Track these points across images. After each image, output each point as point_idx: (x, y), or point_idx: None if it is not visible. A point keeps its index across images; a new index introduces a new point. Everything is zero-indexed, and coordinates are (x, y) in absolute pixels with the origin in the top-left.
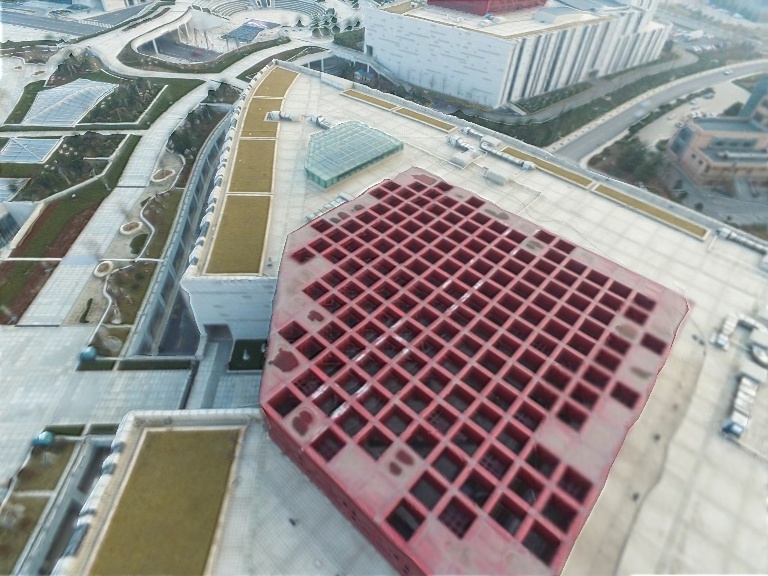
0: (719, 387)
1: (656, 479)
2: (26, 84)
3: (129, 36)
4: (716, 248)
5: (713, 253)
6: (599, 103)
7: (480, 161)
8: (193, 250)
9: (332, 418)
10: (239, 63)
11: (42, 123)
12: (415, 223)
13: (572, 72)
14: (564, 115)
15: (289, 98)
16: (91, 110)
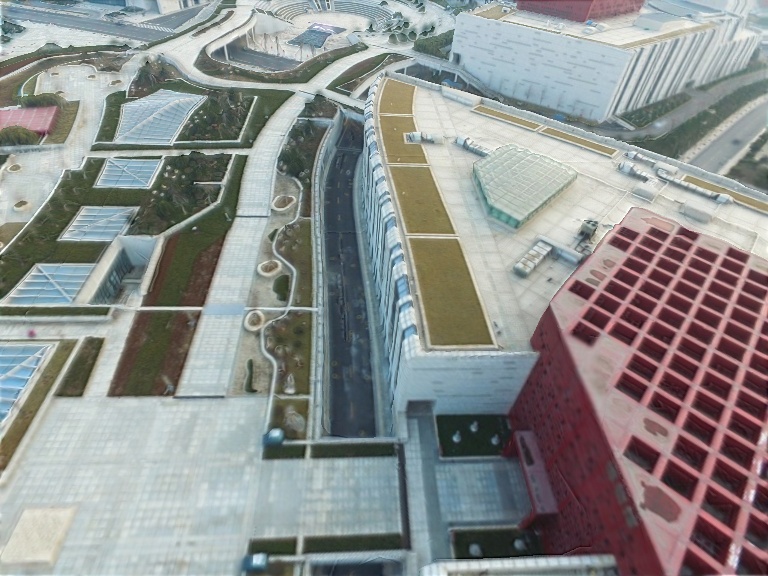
0: None
1: None
2: (105, 95)
3: (201, 42)
4: None
5: None
6: (706, 117)
7: (666, 193)
8: (405, 313)
9: None
10: (324, 72)
11: (136, 141)
12: (688, 285)
13: (673, 83)
14: (679, 131)
15: (418, 115)
16: (185, 126)
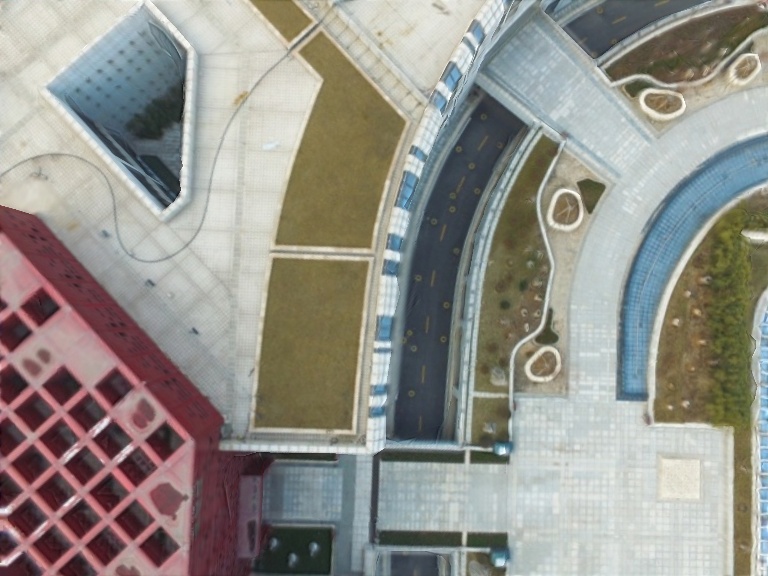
0: None
1: None
2: None
3: None
4: None
5: None
6: None
7: None
8: None
9: (109, 417)
10: None
11: None
12: None
13: None
14: None
15: None
16: None
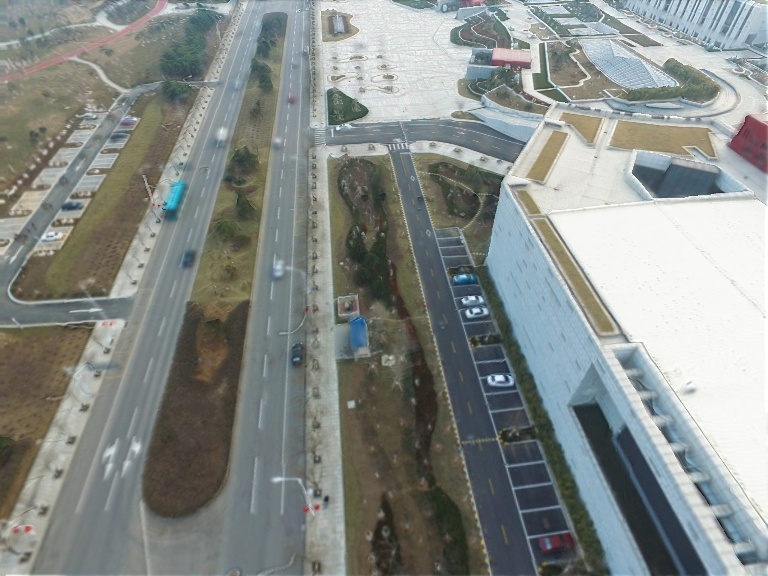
0: None
1: None
2: None
3: None
4: None
5: None
6: None
7: None
8: (750, 2)
9: None
10: None
11: None
12: None
13: None
14: None
15: None
16: None
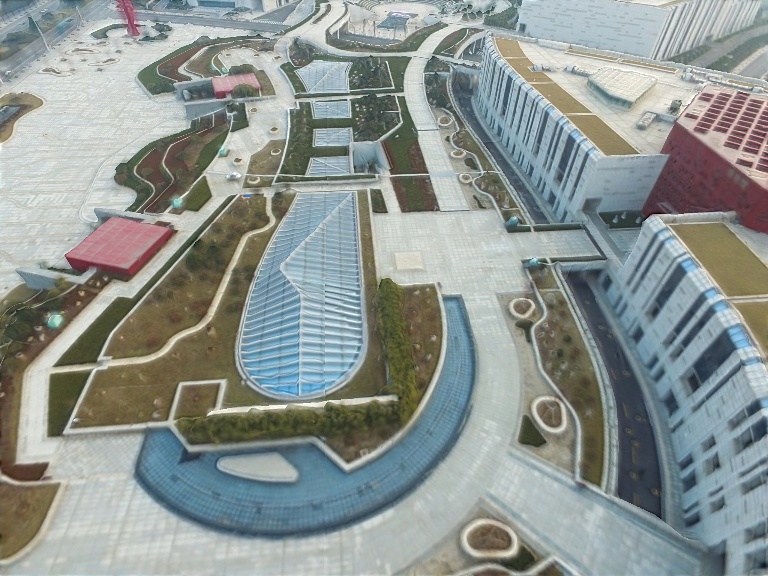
0: None
1: None
2: (276, 66)
3: (321, 27)
4: None
5: None
6: (726, 60)
7: None
8: (585, 144)
9: None
10: (426, 43)
11: (324, 91)
12: (750, 113)
13: (696, 36)
14: None
15: (530, 58)
16: (350, 81)
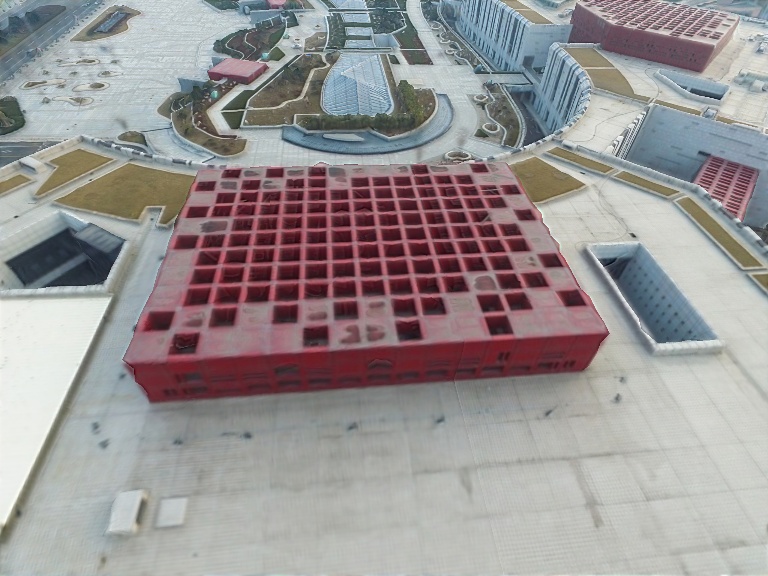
0: (753, 46)
1: (737, 57)
2: None
3: None
4: (743, 23)
5: (742, 24)
6: None
7: None
8: None
9: None
10: None
11: (349, 8)
12: (622, 1)
13: None
14: None
15: None
16: (367, 3)
